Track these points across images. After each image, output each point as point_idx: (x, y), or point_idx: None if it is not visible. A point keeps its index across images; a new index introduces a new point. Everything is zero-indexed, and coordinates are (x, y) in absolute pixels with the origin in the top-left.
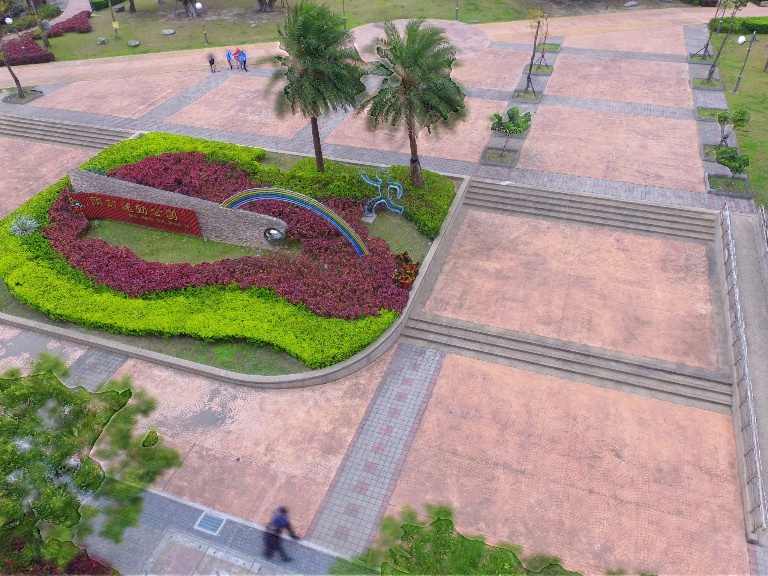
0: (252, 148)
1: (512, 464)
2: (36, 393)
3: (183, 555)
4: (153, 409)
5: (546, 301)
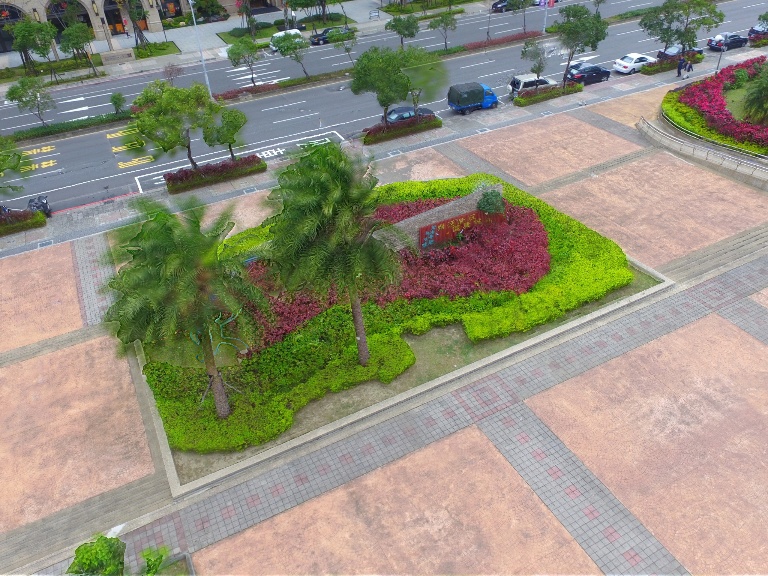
0: (491, 328)
1: (5, 301)
2: (163, 97)
3: (156, 207)
4: (243, 218)
5: (1, 401)
